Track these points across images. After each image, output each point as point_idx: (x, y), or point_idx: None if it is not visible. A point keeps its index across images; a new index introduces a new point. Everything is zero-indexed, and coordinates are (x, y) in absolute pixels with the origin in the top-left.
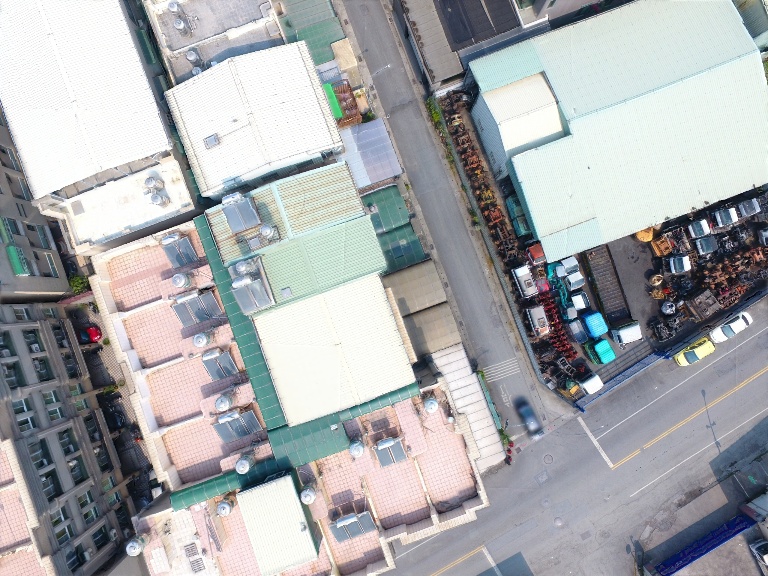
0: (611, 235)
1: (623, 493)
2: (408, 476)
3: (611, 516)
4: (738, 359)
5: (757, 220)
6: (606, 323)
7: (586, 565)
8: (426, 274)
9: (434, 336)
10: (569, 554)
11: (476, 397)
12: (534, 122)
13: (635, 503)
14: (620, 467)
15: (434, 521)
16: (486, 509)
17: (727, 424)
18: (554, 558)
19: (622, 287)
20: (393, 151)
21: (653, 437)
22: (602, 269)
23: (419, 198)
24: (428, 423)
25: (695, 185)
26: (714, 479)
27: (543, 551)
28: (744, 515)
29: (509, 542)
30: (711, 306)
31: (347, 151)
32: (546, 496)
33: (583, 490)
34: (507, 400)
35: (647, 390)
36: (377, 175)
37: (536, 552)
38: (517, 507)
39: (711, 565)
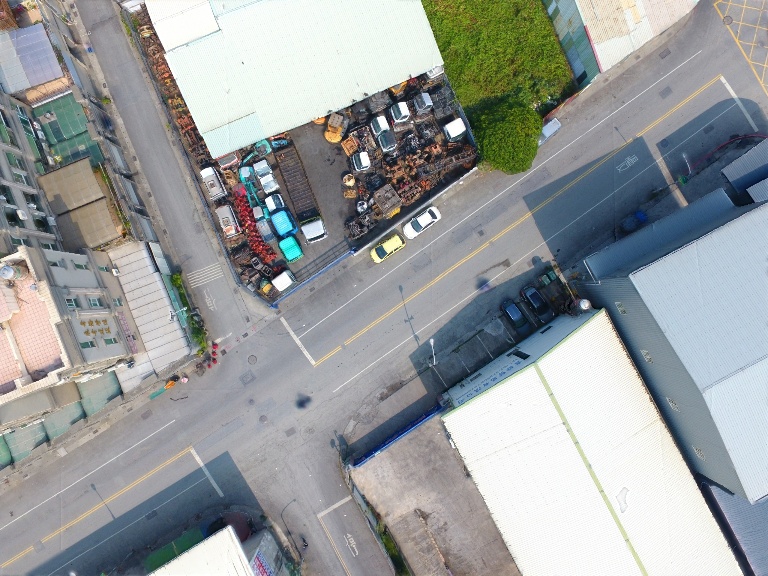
0: (273, 129)
1: (326, 389)
2: (5, 347)
3: (315, 412)
4: (433, 254)
5: (436, 115)
6: (297, 222)
7: (291, 461)
8: (81, 170)
9: (90, 230)
10: (275, 451)
11: (157, 295)
12: (190, 21)
13: (338, 398)
14: (322, 364)
15: (17, 385)
16: (193, 411)
17: (424, 318)
18: (260, 455)
19: (310, 186)
20: (54, 55)
21: (353, 333)
22: (292, 170)
23: (121, 111)
24: (23, 295)
25: (353, 77)
26: (414, 372)
27: (249, 449)
28: (437, 403)
29: (216, 442)
30: (390, 199)
31: (6, 55)
32: (251, 395)
33: (287, 388)
34: (211, 304)
35: (346, 288)
36: (37, 78)
37: (243, 450)
38: (223, 408)
39: (411, 455)
